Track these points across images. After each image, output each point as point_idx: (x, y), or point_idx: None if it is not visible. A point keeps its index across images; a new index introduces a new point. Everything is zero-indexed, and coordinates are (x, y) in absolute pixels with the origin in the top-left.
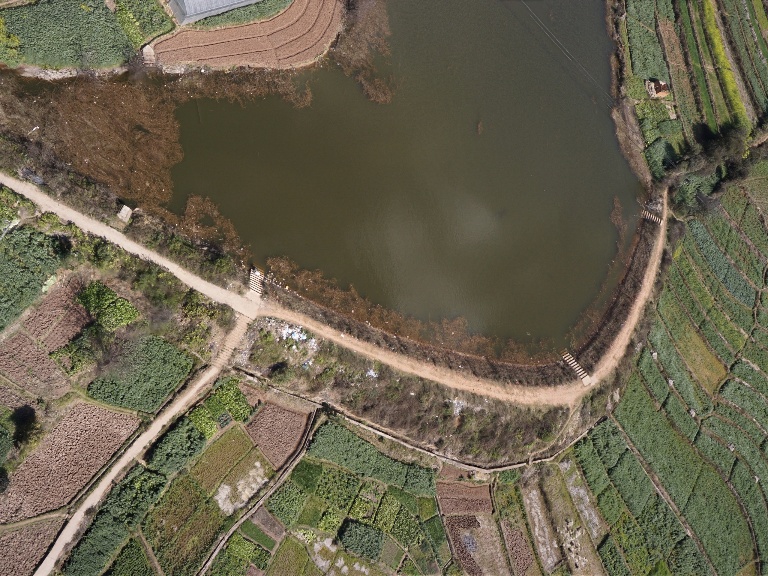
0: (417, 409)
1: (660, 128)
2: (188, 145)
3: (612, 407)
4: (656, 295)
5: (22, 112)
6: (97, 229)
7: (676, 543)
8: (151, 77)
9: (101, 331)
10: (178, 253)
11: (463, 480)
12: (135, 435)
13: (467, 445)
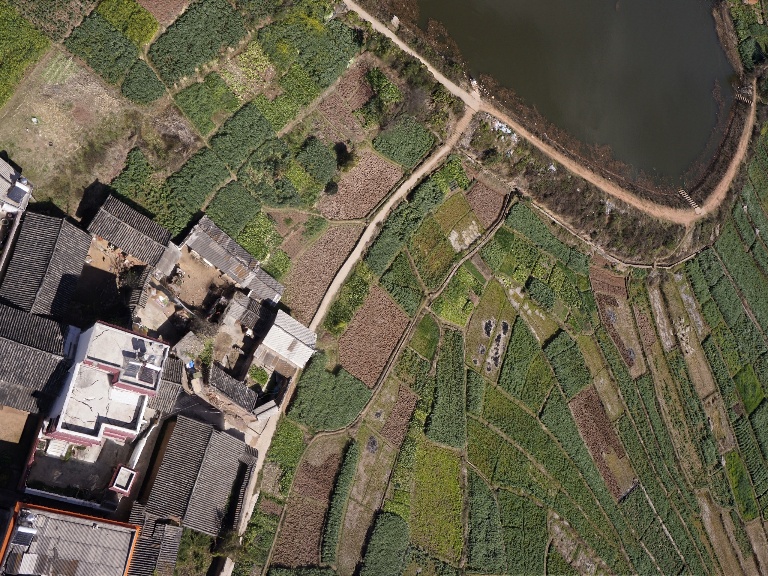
0: (581, 203)
1: (751, 29)
2: None
3: (714, 239)
4: (748, 159)
5: None
6: (380, 28)
7: (760, 355)
8: None
9: (381, 102)
10: (429, 55)
11: (608, 268)
12: (401, 181)
13: (613, 239)
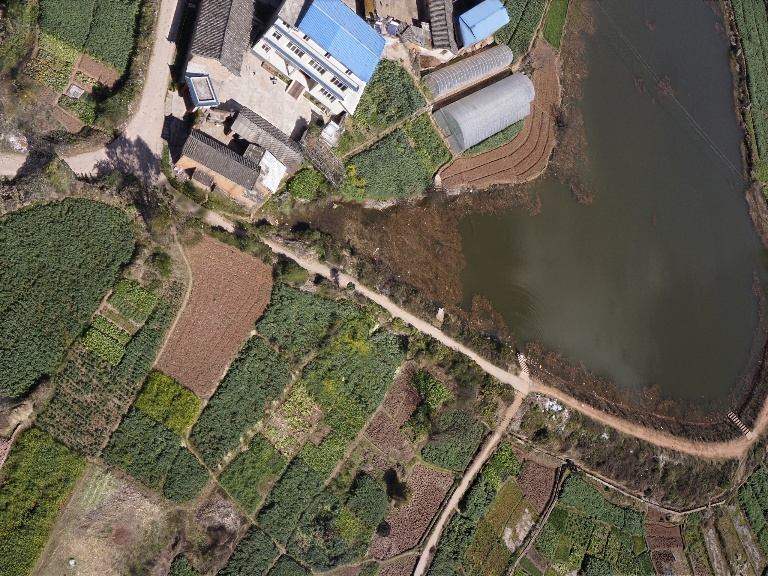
0: (635, 464)
1: None
2: (468, 254)
3: (765, 457)
4: None
5: (368, 237)
6: (426, 329)
7: None
8: (443, 201)
9: (429, 408)
10: (476, 345)
11: (663, 522)
12: (452, 489)
13: (668, 493)
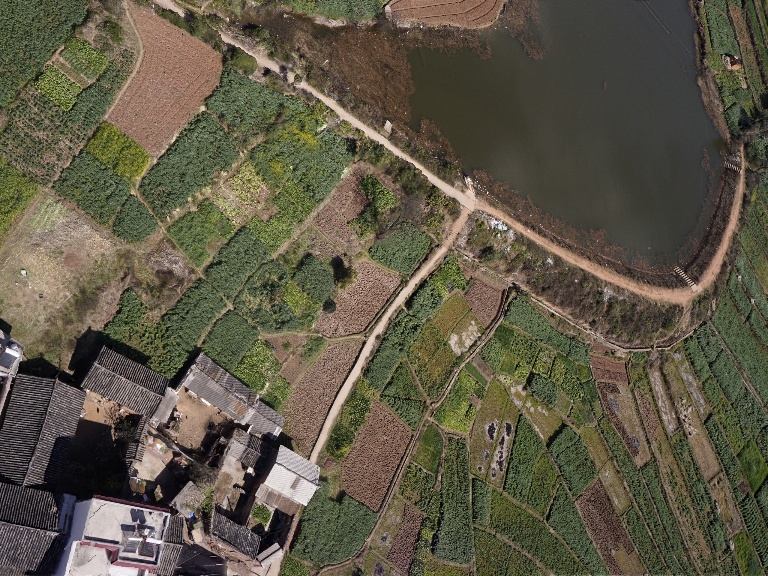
0: (579, 293)
1: (735, 95)
2: (417, 81)
3: (711, 314)
4: (740, 229)
5: (318, 49)
6: (373, 135)
7: (762, 428)
8: None
9: (377, 210)
10: (423, 158)
11: (608, 355)
12: (399, 289)
13: (612, 327)
